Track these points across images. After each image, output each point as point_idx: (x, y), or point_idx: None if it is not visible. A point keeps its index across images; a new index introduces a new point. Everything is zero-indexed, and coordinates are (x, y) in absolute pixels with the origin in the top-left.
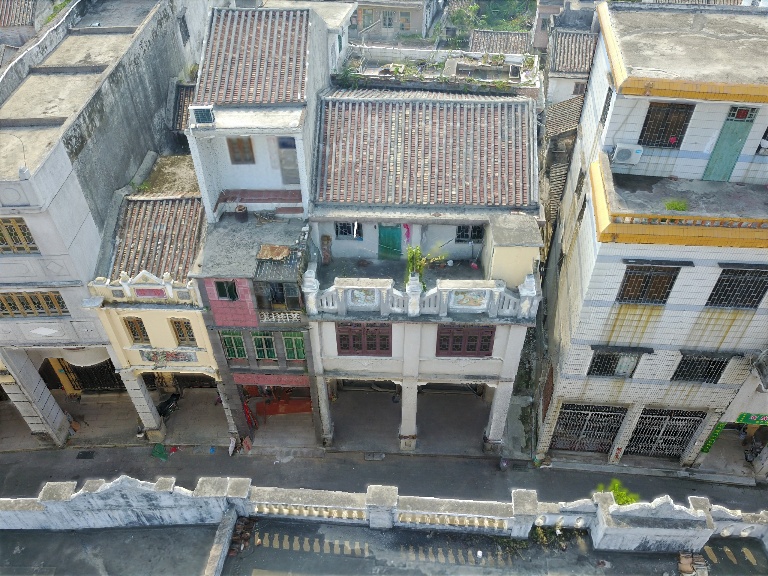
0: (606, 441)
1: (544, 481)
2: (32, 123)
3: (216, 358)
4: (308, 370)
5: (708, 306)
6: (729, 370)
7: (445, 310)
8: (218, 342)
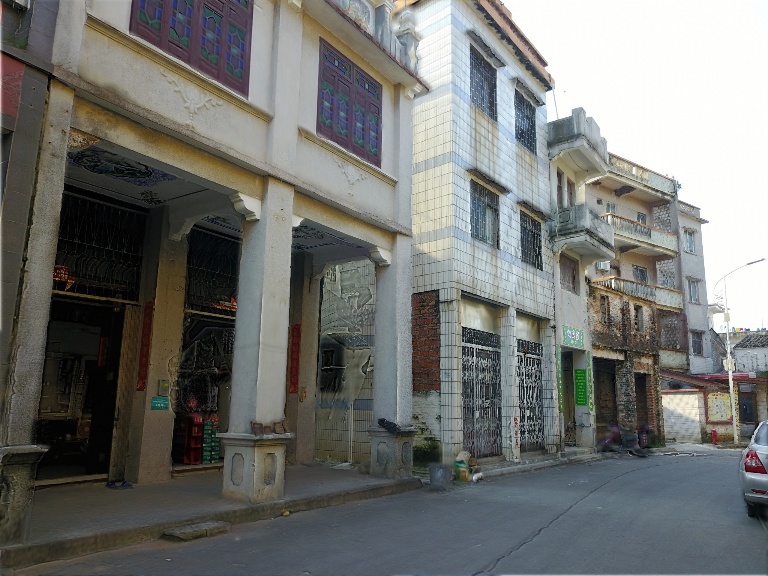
0: (494, 424)
1: (502, 485)
2: None
3: None
4: (29, 41)
5: (516, 140)
6: (543, 248)
7: (338, 3)
8: None
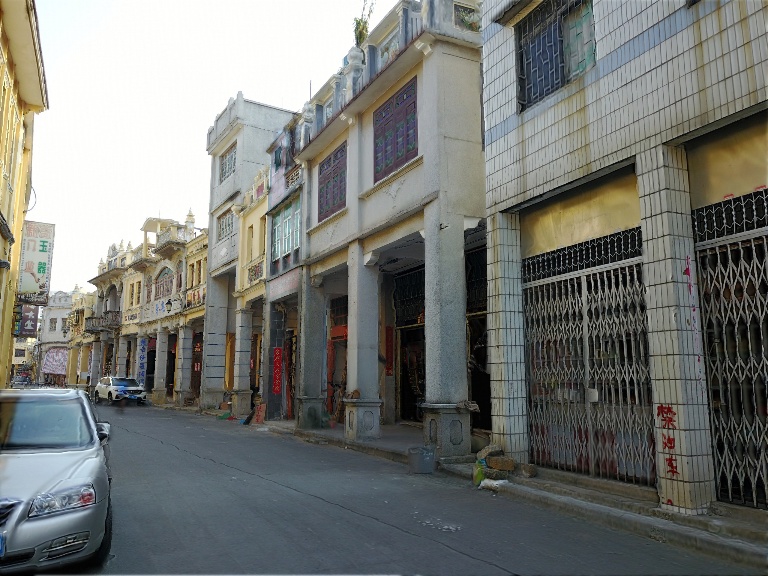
0: None
1: None
2: None
3: (267, 261)
4: (299, 258)
5: None
6: None
7: (368, 81)
8: None
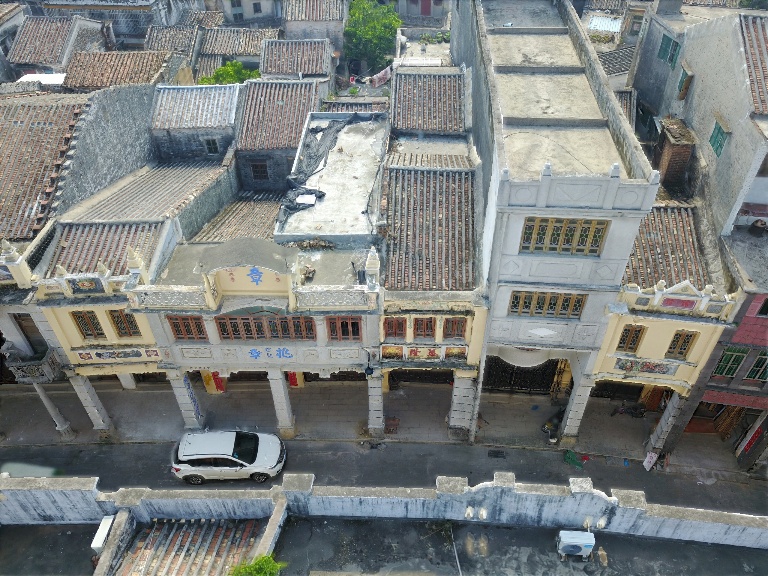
0: None
1: None
2: (549, 123)
3: (701, 374)
4: None
5: None
6: None
7: None
8: (717, 358)
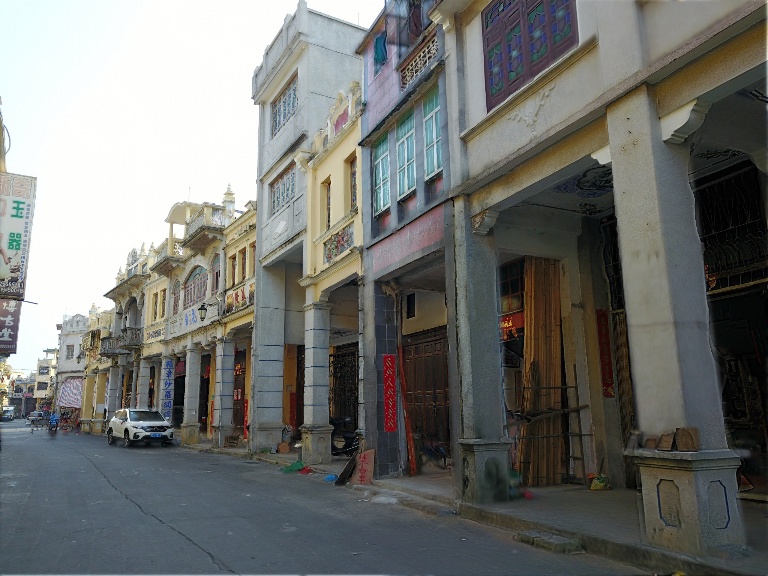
0: None
1: None
2: None
3: (364, 218)
4: (444, 188)
5: None
6: None
7: None
8: (368, 177)
